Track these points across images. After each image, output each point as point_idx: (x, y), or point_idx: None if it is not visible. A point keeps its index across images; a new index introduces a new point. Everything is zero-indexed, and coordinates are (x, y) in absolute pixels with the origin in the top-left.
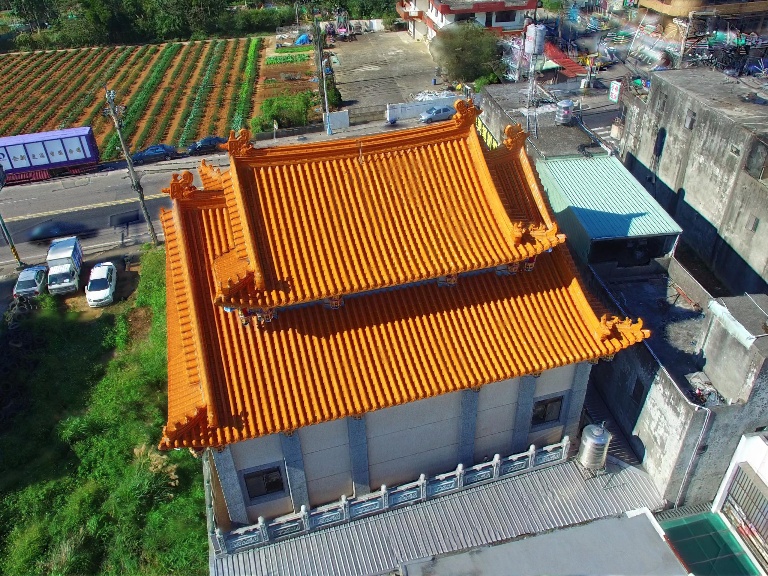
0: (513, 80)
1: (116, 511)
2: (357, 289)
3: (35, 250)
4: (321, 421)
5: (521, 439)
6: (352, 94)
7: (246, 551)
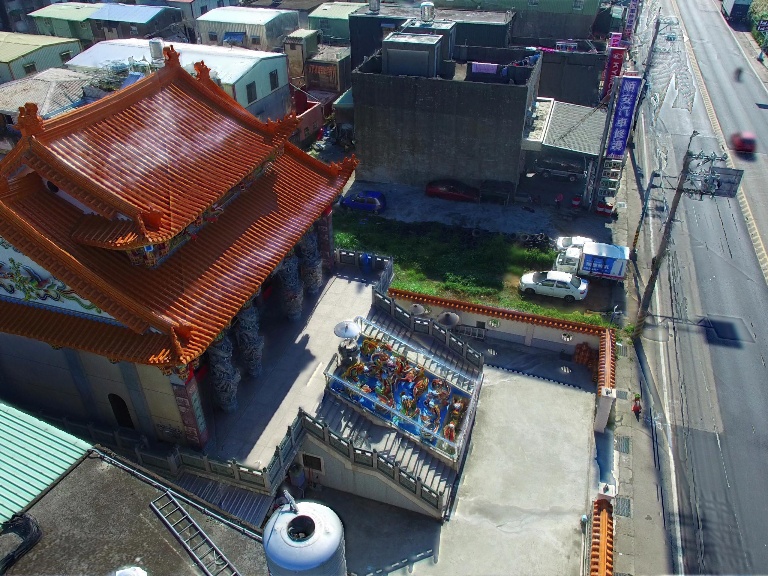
0: None
1: None
2: None
3: (670, 263)
4: None
5: None
6: None
7: None
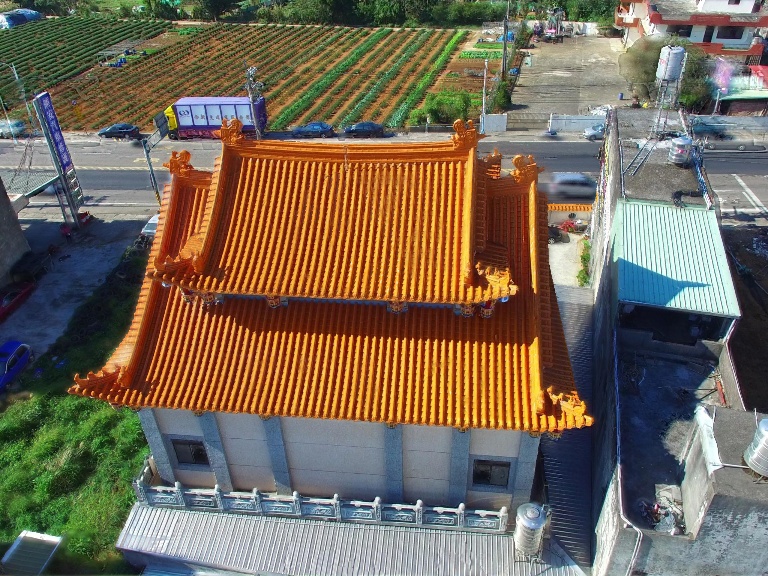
0: None
1: (120, 438)
2: (284, 293)
3: None
4: (216, 410)
5: (458, 493)
6: (526, 98)
7: (165, 508)
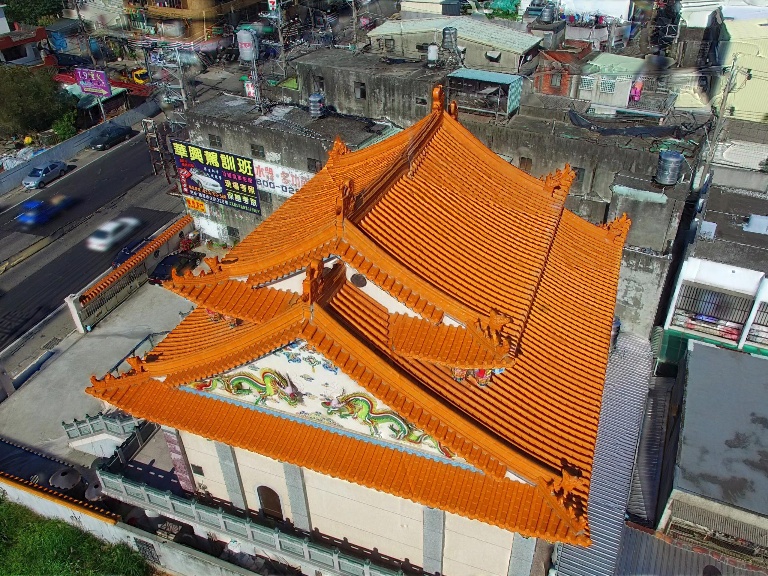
0: (176, 102)
1: None
2: None
3: None
4: None
5: None
6: None
7: None
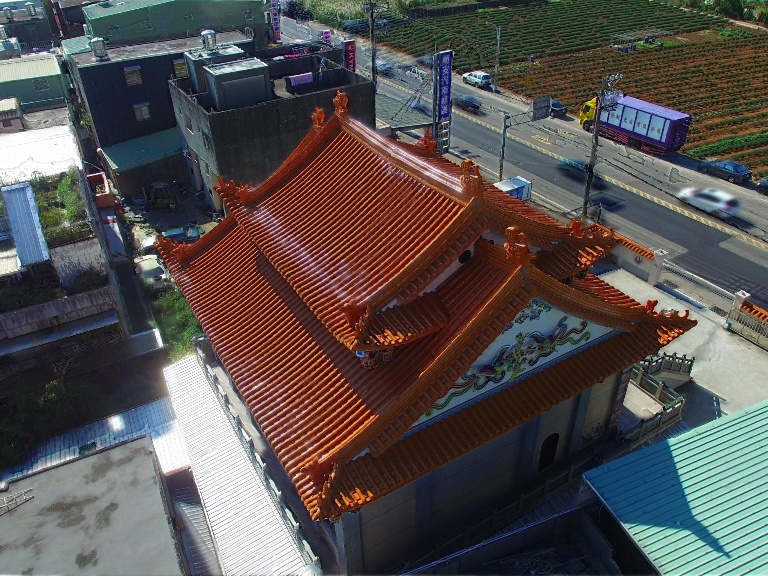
0: None
1: None
2: None
3: None
4: None
5: None
6: None
7: None
